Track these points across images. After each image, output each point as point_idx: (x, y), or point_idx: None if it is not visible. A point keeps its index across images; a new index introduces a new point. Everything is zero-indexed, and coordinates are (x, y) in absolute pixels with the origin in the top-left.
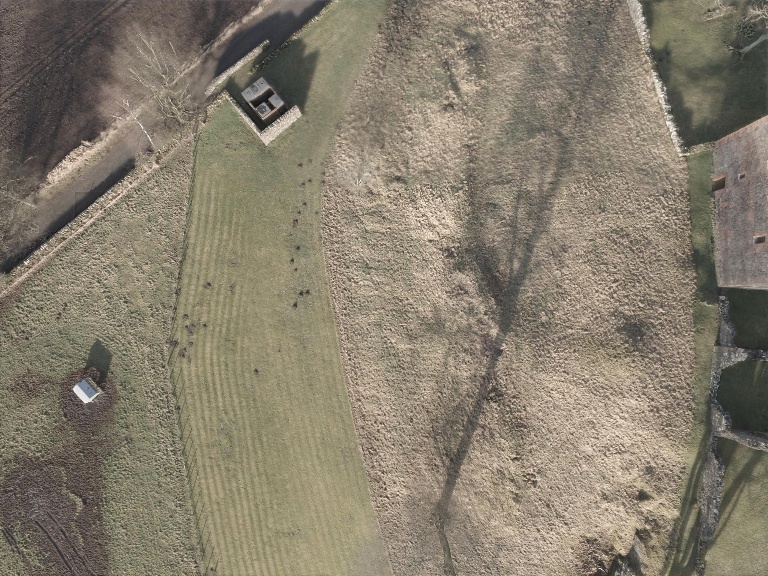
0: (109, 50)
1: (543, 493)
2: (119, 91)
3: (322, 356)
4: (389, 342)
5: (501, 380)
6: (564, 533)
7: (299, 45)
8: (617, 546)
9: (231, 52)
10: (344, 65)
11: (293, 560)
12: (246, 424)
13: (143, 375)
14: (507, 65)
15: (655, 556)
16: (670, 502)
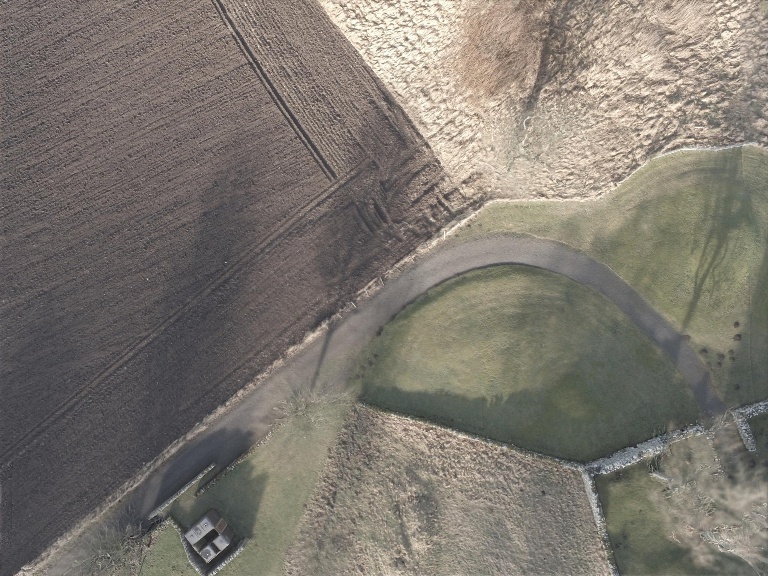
0: (49, 465)
1: None
2: (60, 508)
3: None
4: None
5: None
6: None
7: (246, 467)
8: None
9: (176, 468)
10: (293, 488)
11: None
12: None
13: None
14: (460, 518)
15: None
16: None
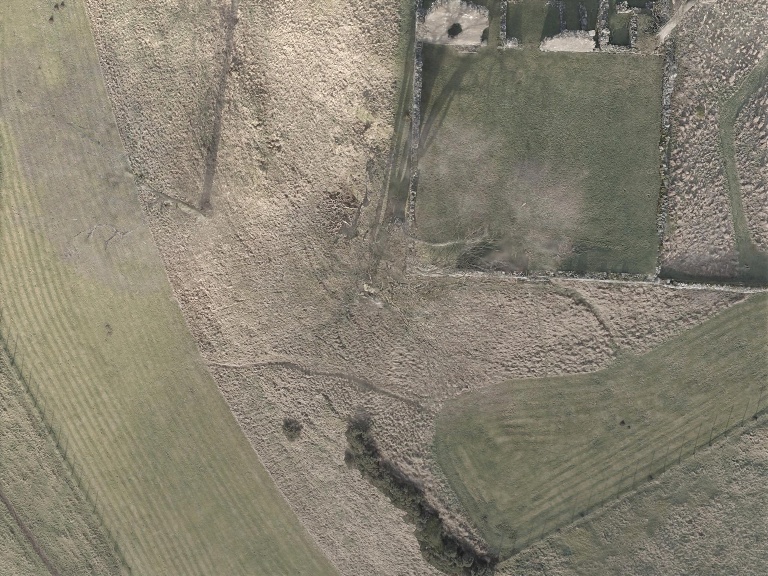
0: None
1: (287, 157)
2: None
3: (83, 69)
4: (144, 42)
5: (240, 49)
6: (308, 192)
7: None
8: (354, 192)
9: None
10: None
11: (73, 282)
12: (14, 148)
13: None
14: None
15: (376, 179)
16: (384, 119)
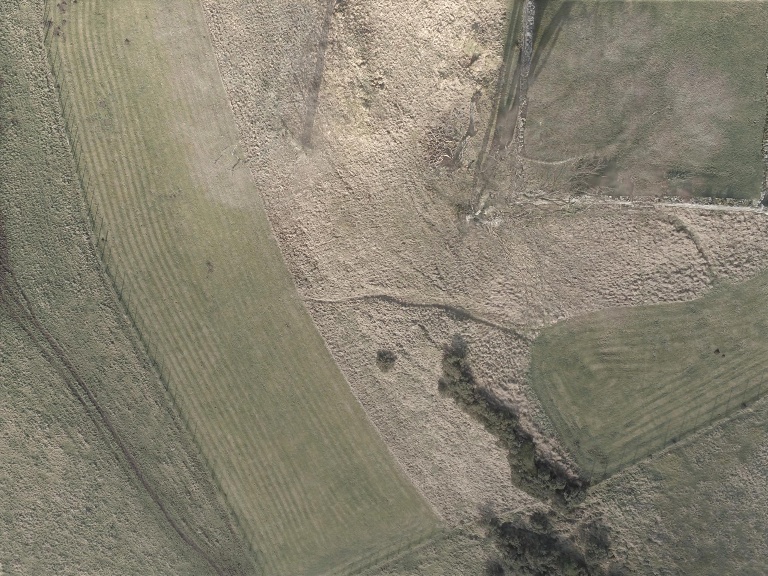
0: None
1: (390, 94)
2: None
3: (187, 18)
4: None
5: None
6: (411, 127)
7: None
8: (458, 125)
9: None
10: None
11: (177, 222)
12: (122, 94)
13: (22, 58)
14: None
15: (484, 109)
16: (493, 50)
